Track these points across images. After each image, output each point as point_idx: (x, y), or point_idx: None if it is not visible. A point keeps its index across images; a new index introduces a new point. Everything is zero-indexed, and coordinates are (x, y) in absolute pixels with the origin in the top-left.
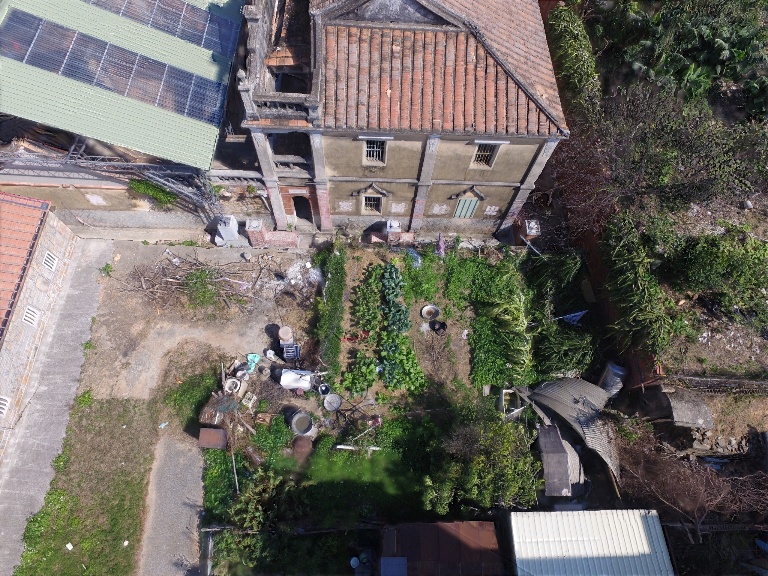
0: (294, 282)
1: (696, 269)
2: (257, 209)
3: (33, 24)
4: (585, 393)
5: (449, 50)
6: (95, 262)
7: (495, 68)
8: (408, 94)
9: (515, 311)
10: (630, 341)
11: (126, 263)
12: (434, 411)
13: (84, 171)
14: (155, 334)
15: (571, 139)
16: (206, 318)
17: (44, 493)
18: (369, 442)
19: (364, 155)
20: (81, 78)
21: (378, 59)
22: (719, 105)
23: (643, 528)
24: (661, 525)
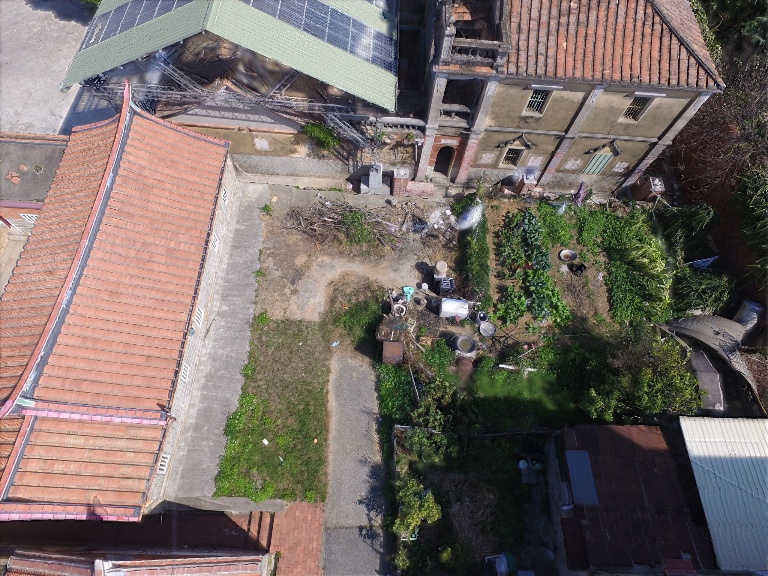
0: (437, 226)
1: None
2: (404, 159)
3: None
4: (723, 326)
5: (621, 8)
6: (255, 202)
7: (660, 26)
8: (582, 47)
9: (654, 253)
10: None
11: (283, 204)
12: (579, 341)
13: (266, 114)
14: (317, 266)
15: None
16: (362, 254)
17: (237, 396)
18: (528, 363)
19: (526, 105)
20: (293, 23)
21: (557, 14)
22: None
23: None
24: None
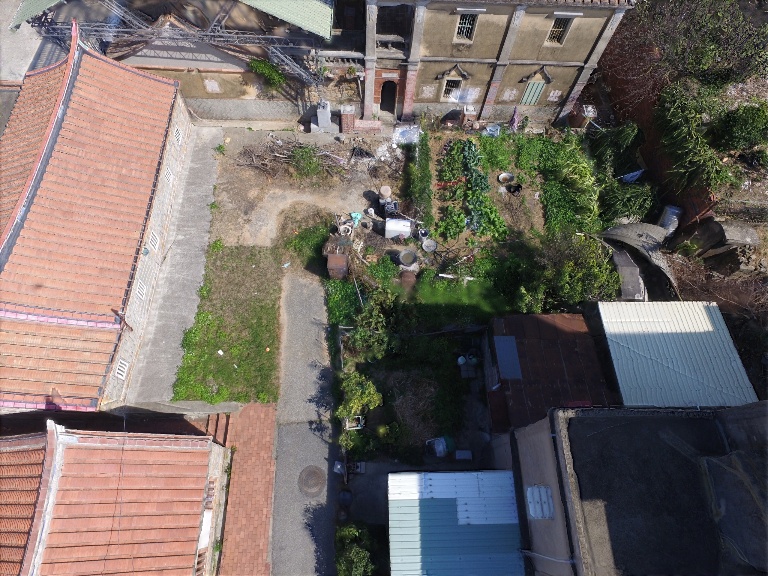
0: (384, 159)
1: (739, 125)
2: (350, 96)
3: None
4: (647, 230)
5: None
6: (209, 143)
7: None
8: None
9: (583, 169)
10: (686, 181)
11: (236, 144)
12: (516, 253)
13: (211, 52)
14: (269, 198)
15: (624, 30)
16: (311, 186)
17: (193, 314)
18: (466, 271)
19: (456, 32)
20: None
21: None
22: (748, 10)
23: (706, 314)
24: (720, 312)
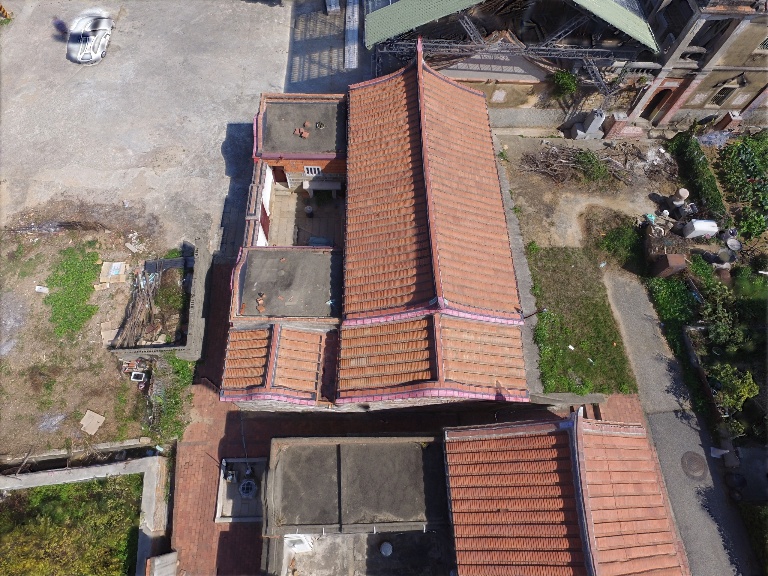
0: (656, 163)
1: None
2: (622, 104)
3: None
4: None
5: None
6: None
7: None
8: None
9: None
10: None
11: (515, 151)
12: None
13: (520, 64)
14: (564, 202)
15: None
16: (599, 190)
17: (534, 312)
18: None
19: None
20: None
21: None
22: None
23: None
24: None
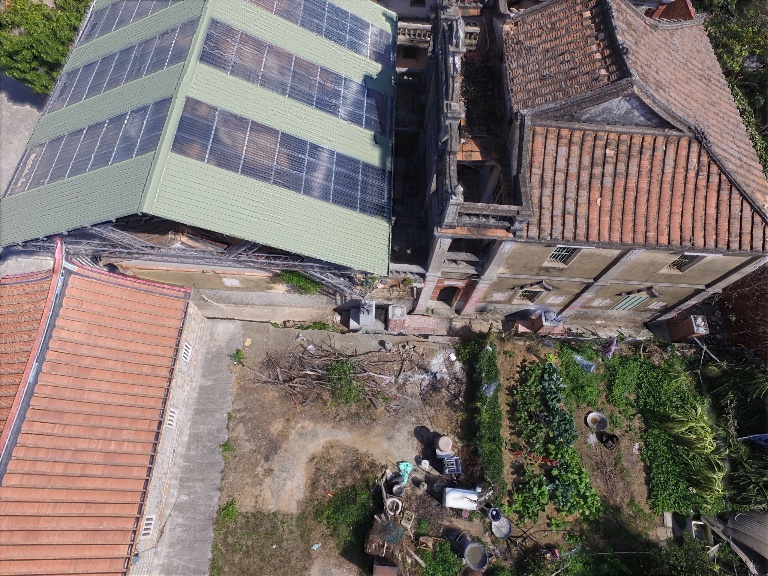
0: (439, 377)
1: None
2: (401, 295)
3: (209, 115)
4: None
5: (669, 156)
6: (225, 347)
7: (718, 176)
8: (620, 203)
9: (703, 431)
10: None
11: (258, 349)
12: (613, 541)
13: (233, 261)
14: (297, 435)
15: None
16: (350, 418)
17: None
18: None
19: (548, 258)
20: (260, 176)
21: (589, 163)
22: None
23: None
24: None
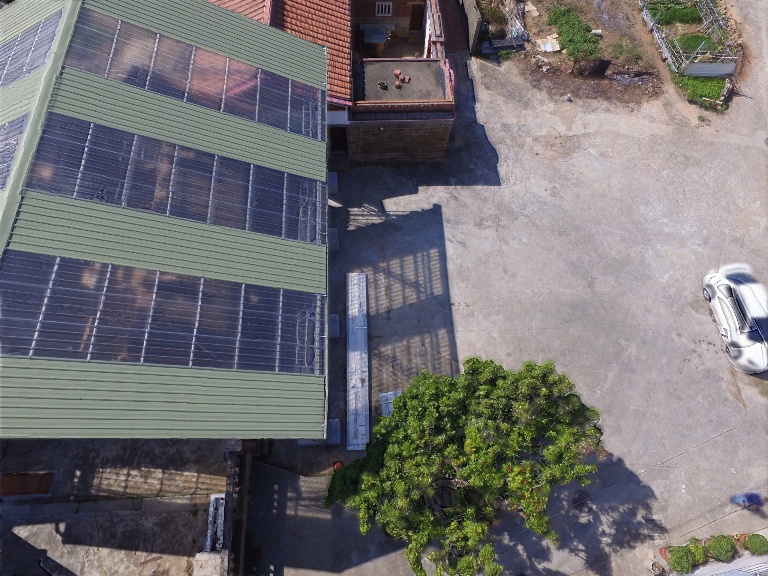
0: None
1: None
2: None
3: None
4: None
5: None
6: None
7: None
8: None
9: None
10: None
11: None
12: None
13: None
14: None
15: None
16: None
17: None
18: None
19: None
20: (6, 44)
21: None
22: None
23: None
24: None
